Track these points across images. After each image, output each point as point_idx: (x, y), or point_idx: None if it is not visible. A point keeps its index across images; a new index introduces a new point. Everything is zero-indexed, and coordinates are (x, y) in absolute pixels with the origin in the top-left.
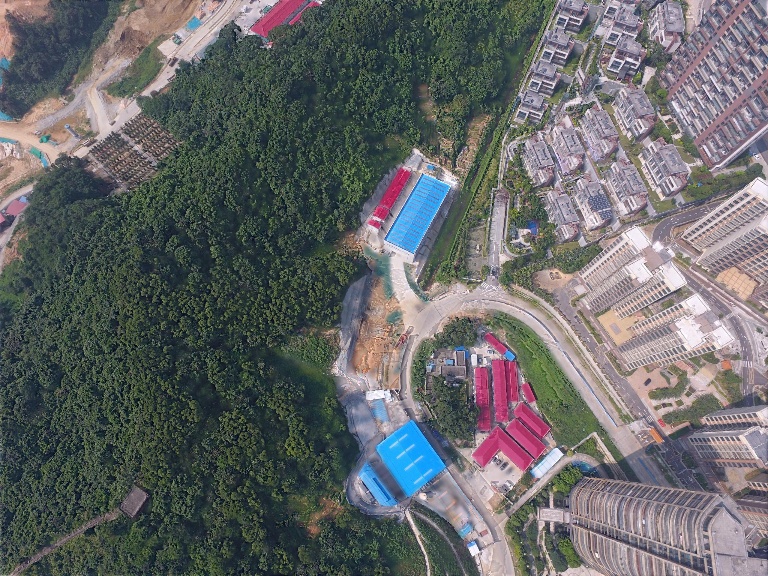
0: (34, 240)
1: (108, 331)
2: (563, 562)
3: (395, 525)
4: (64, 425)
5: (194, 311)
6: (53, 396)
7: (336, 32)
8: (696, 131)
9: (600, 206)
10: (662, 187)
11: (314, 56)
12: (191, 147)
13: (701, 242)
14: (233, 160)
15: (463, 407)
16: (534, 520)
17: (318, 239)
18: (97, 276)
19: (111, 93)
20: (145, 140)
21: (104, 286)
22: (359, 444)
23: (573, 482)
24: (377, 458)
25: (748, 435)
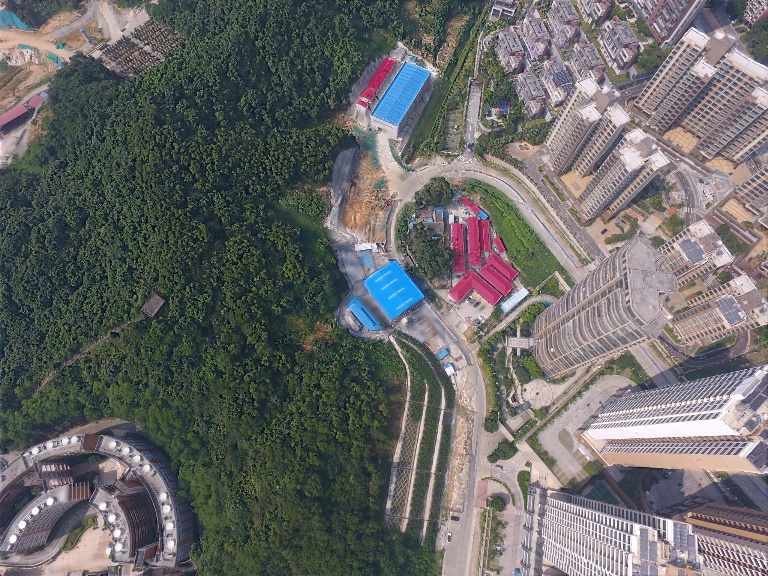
0: (58, 112)
1: (127, 177)
2: (527, 374)
3: (380, 343)
4: (89, 259)
5: (202, 156)
6: (79, 234)
7: None
8: (648, 12)
9: (563, 80)
10: (617, 60)
11: None
12: (197, 35)
13: (650, 105)
14: (235, 37)
15: None
16: (503, 347)
17: (311, 114)
18: (116, 131)
19: (121, 6)
20: (153, 42)
21: (123, 138)
22: (348, 283)
23: (537, 312)
24: (364, 293)
25: (681, 243)
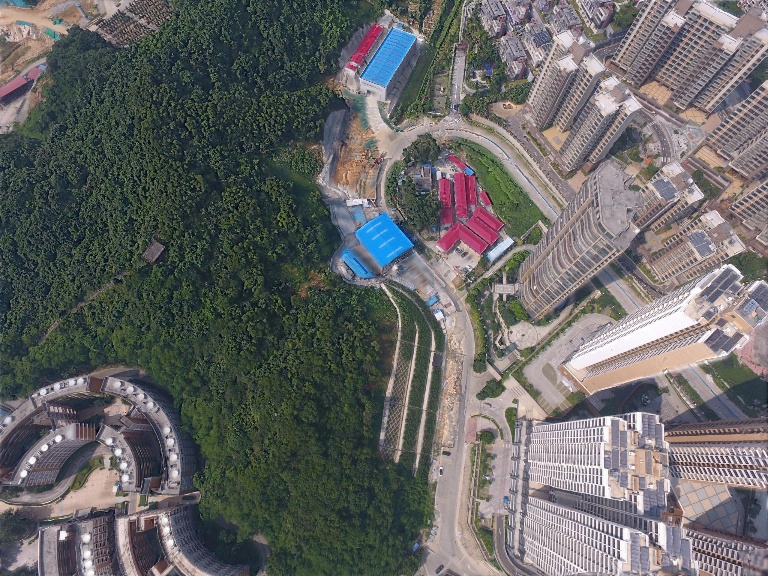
0: (57, 78)
1: (125, 135)
2: (512, 316)
3: (372, 289)
4: (91, 214)
5: (198, 112)
6: (80, 191)
7: None
8: None
9: (543, 40)
10: (594, 20)
11: None
12: (190, 3)
13: (626, 60)
14: (227, 3)
15: None
16: (490, 293)
17: (302, 78)
18: (114, 91)
19: None
20: (148, 15)
21: (121, 97)
22: (341, 235)
23: (521, 259)
24: (356, 244)
25: (654, 182)
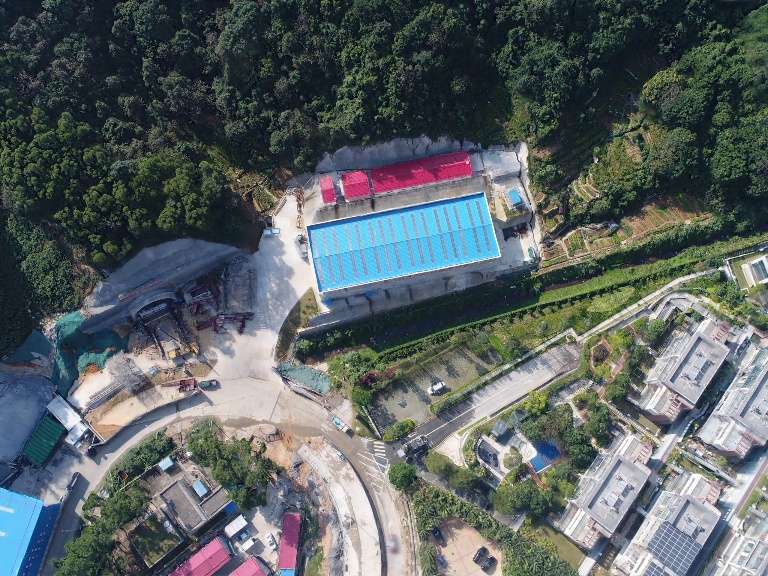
0: None
1: None
2: None
3: None
4: None
5: None
6: None
7: None
8: None
9: (666, 556)
10: None
11: None
12: None
13: None
14: None
15: (120, 569)
16: None
17: (226, 128)
18: None
19: None
20: None
21: None
22: None
23: None
24: None
25: None
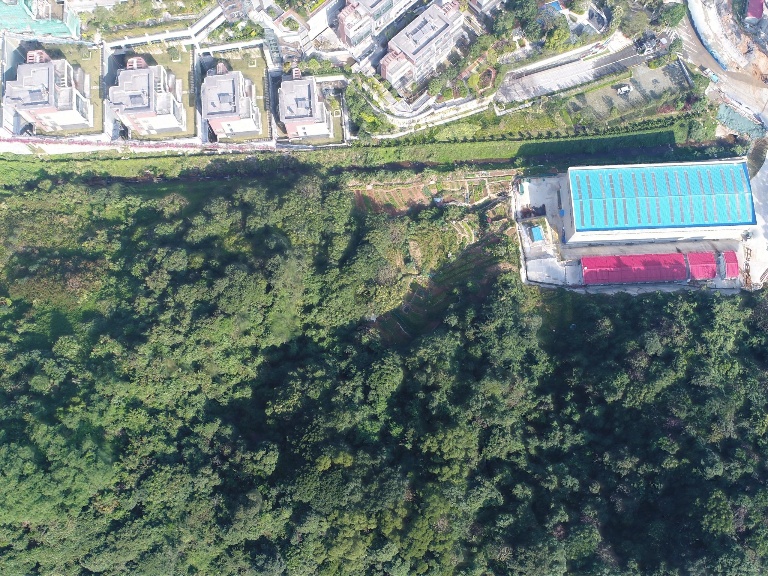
0: None
1: None
2: None
3: None
4: None
5: None
6: None
7: (446, 569)
8: None
9: None
10: None
11: (562, 571)
12: None
13: None
14: None
15: None
16: None
17: None
18: None
19: None
20: None
21: None
22: None
23: None
24: None
25: None
